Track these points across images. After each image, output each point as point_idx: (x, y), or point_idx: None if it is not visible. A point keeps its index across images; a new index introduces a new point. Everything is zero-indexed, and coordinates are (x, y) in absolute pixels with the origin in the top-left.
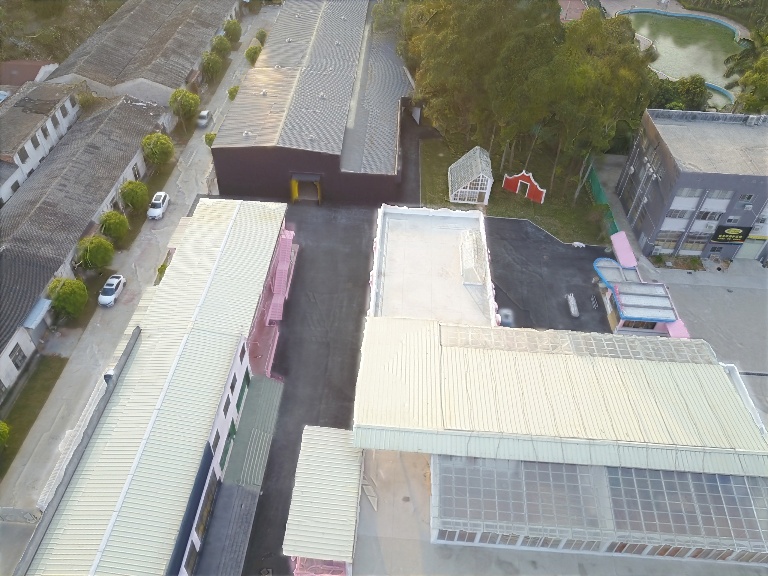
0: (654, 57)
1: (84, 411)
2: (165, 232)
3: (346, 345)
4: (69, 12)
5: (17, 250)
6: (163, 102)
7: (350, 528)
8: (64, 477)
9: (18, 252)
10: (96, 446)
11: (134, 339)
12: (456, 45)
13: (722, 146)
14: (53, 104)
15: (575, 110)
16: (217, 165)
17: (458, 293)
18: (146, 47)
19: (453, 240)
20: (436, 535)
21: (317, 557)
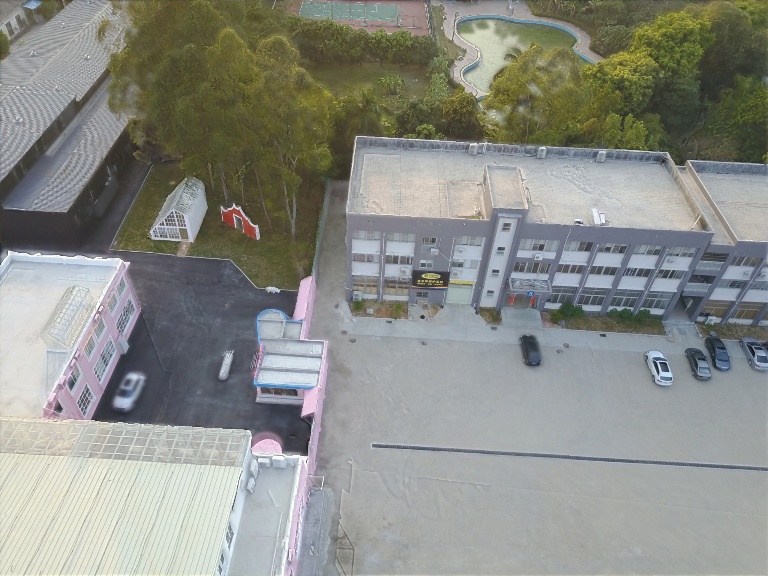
0: (305, 84)
1: None
2: None
3: None
4: None
5: None
6: None
7: None
8: None
9: None
10: None
11: None
12: (126, 66)
13: (425, 180)
14: None
15: (229, 143)
16: None
17: (33, 363)
18: None
19: None
20: None
21: None
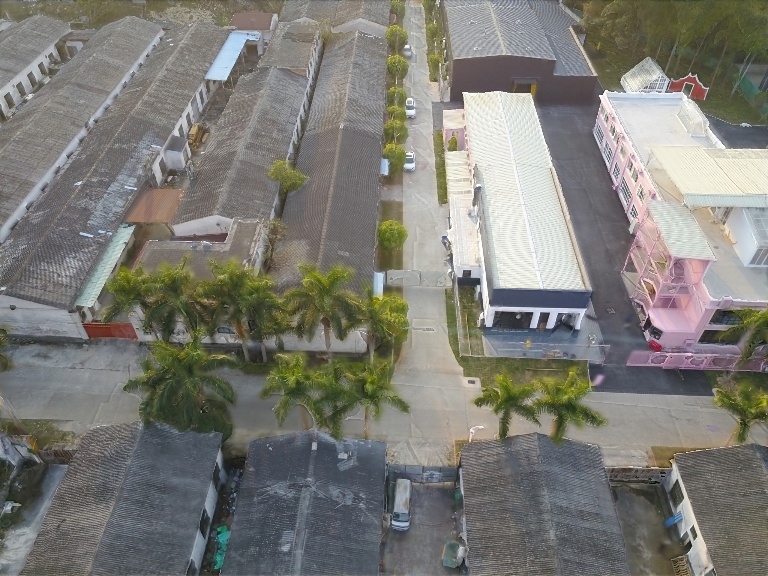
0: None
1: (453, 219)
2: (423, 126)
3: (598, 190)
4: None
5: (351, 127)
6: None
7: (706, 245)
8: None
9: (353, 128)
10: (492, 225)
11: None
12: None
13: None
14: (312, 36)
15: (753, 11)
16: (454, 75)
17: (690, 142)
18: None
19: (668, 112)
20: (751, 259)
21: (695, 257)
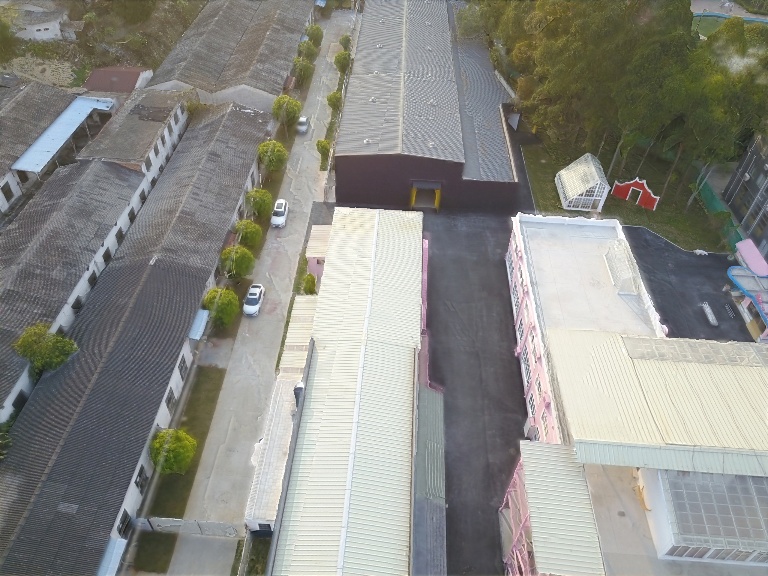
0: None
1: (268, 424)
2: (291, 240)
3: (495, 355)
4: (151, 17)
5: (169, 260)
6: (262, 108)
7: (595, 545)
8: (283, 492)
9: (170, 262)
10: (303, 460)
11: (311, 351)
12: (580, 52)
13: None
14: (168, 111)
15: (711, 118)
16: (338, 173)
17: (615, 303)
18: (237, 53)
19: (595, 249)
20: (666, 551)
21: (572, 575)
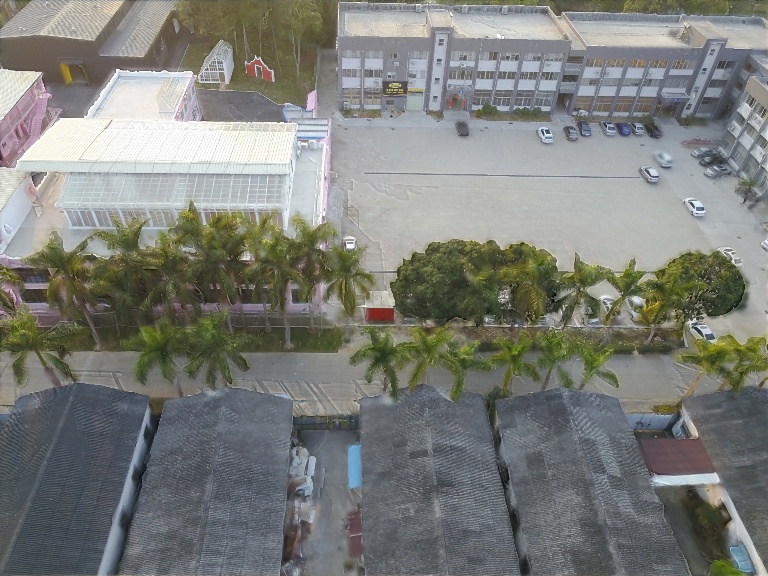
0: None
1: None
2: None
3: None
4: None
5: None
6: None
7: None
8: None
9: None
10: None
11: None
12: None
13: (387, 24)
14: None
15: None
16: None
17: (152, 117)
18: None
19: None
20: (69, 221)
21: None
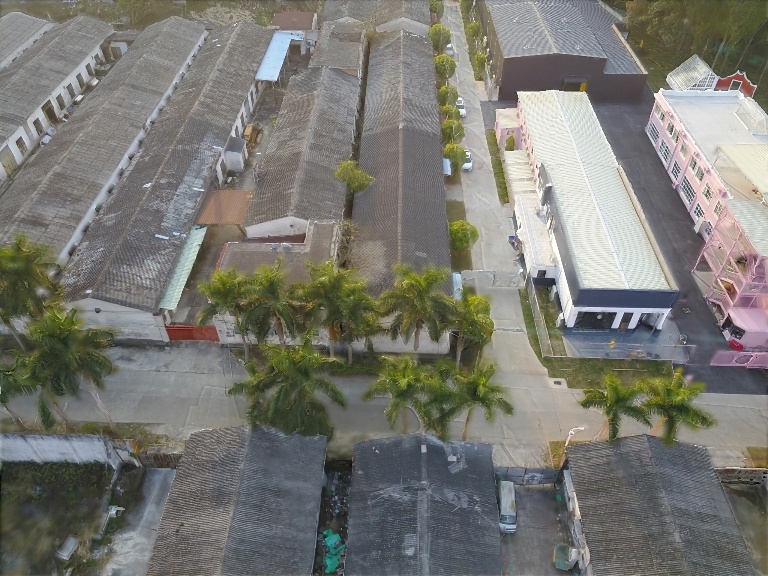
0: None
1: (522, 219)
2: (474, 125)
3: (658, 189)
4: None
5: (410, 127)
6: None
7: None
8: None
9: (412, 128)
10: (568, 225)
11: None
12: None
13: None
14: (359, 35)
15: None
16: (504, 73)
17: (752, 140)
18: None
19: (726, 110)
20: None
21: None
